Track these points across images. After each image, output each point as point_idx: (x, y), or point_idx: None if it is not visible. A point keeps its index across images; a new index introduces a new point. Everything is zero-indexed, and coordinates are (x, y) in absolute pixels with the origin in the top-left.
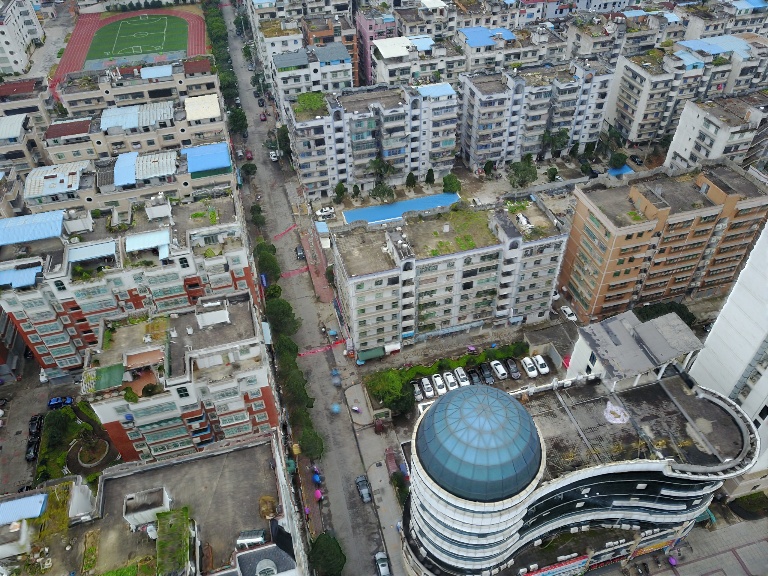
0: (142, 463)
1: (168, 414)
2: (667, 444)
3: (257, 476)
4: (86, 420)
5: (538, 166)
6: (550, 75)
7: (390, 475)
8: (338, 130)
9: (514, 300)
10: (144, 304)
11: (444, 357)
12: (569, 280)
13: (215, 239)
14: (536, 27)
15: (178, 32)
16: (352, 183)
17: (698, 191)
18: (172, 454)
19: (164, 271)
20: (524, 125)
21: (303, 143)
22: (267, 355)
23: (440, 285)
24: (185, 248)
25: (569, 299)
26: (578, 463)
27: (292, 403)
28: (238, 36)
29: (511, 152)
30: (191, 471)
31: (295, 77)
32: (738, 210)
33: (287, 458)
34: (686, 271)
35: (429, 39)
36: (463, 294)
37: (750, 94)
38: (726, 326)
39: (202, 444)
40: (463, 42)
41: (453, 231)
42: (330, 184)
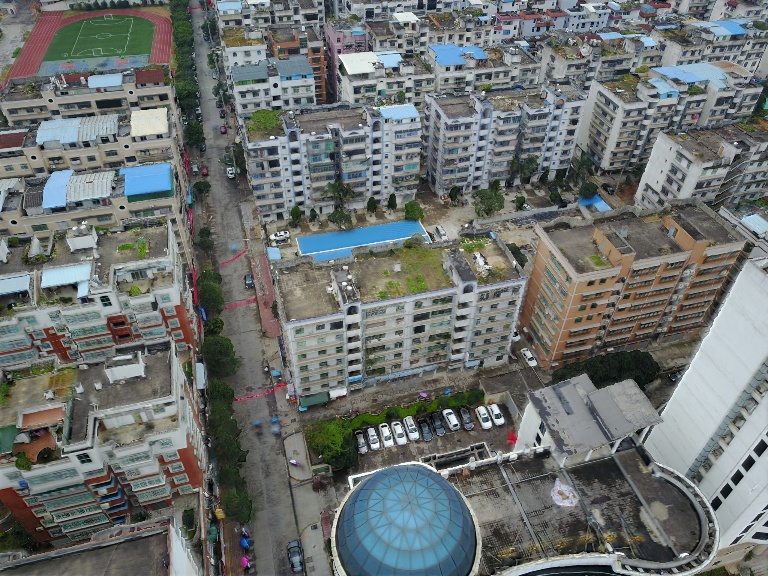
0: (16, 555)
1: (69, 481)
2: (618, 532)
3: (147, 575)
4: None
5: (506, 192)
6: (520, 99)
7: (325, 541)
8: (295, 151)
9: (470, 344)
10: (63, 343)
11: (394, 403)
12: (530, 322)
13: (144, 274)
14: (510, 46)
15: (143, 35)
16: (310, 206)
17: (666, 234)
18: (77, 520)
19: (83, 310)
20: (492, 150)
21: (256, 164)
22: (198, 402)
23: (389, 329)
24: (106, 286)
25: (530, 341)
26: (519, 554)
27: (221, 458)
28: (205, 41)
29: (479, 177)
30: (71, 567)
31: (254, 91)
32: (707, 256)
33: (210, 523)
34: (652, 317)
35: (397, 55)
36: (414, 338)
37: (724, 127)
38: (687, 394)
39: (112, 509)
40: (433, 60)
41: (405, 270)
42: (286, 207)
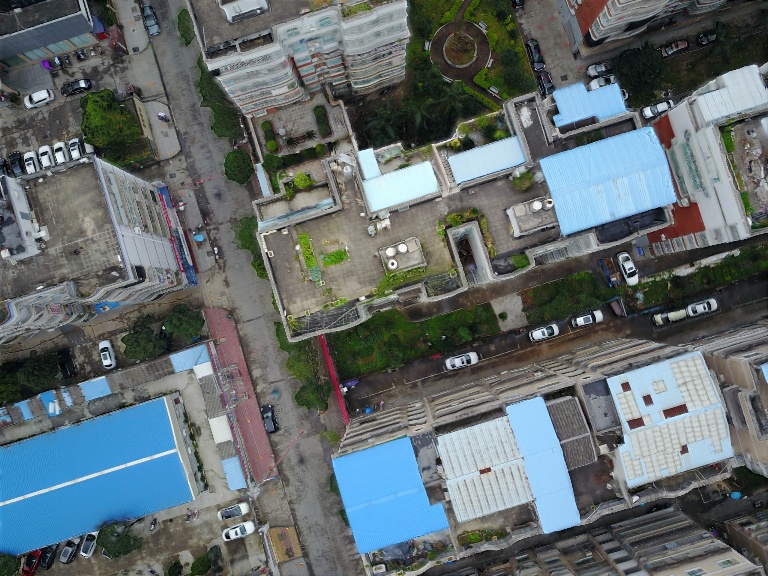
0: None
1: None
2: None
3: None
4: (487, 94)
5: None
6: None
7: None
8: None
9: None
10: None
11: None
12: None
13: None
14: None
15: None
16: None
17: None
18: None
19: None
20: None
21: None
22: None
23: None
24: (329, 159)
25: None
26: None
27: None
28: None
29: None
30: None
31: None
32: None
33: None
34: None
35: None
36: None
37: None
38: None
39: None
40: None
41: None
42: None
